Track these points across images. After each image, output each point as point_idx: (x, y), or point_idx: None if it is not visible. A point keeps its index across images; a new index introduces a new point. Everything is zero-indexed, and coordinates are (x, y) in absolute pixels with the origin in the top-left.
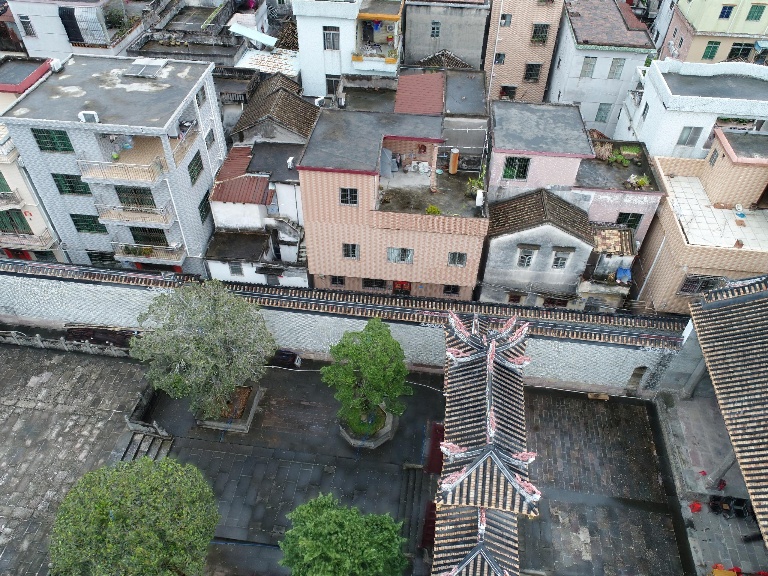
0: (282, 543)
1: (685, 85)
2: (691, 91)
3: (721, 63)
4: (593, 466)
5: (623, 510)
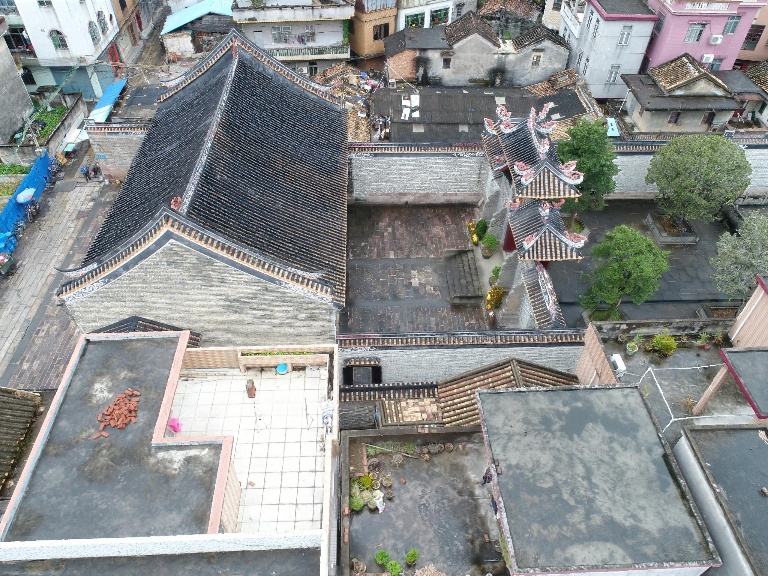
0: (615, 182)
1: None
2: None
3: None
4: (405, 325)
5: (385, 299)
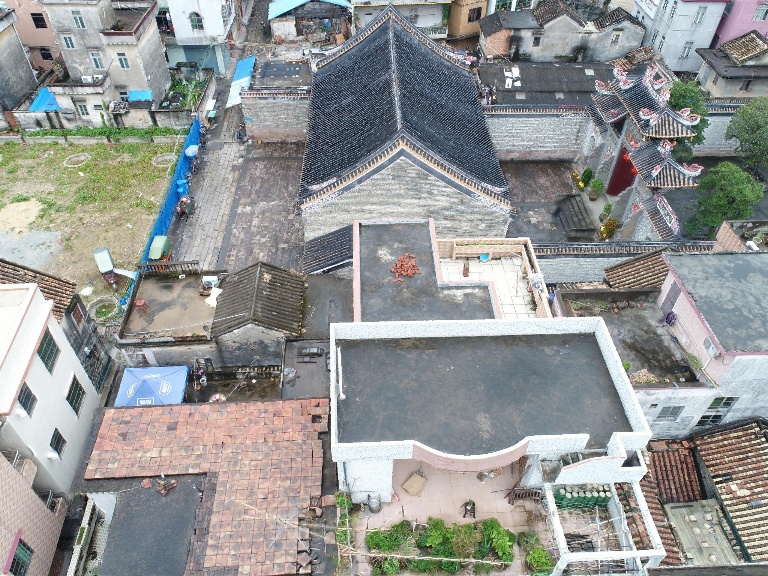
0: None
1: (571, 403)
2: (560, 384)
3: (514, 446)
4: None
5: (511, 233)
